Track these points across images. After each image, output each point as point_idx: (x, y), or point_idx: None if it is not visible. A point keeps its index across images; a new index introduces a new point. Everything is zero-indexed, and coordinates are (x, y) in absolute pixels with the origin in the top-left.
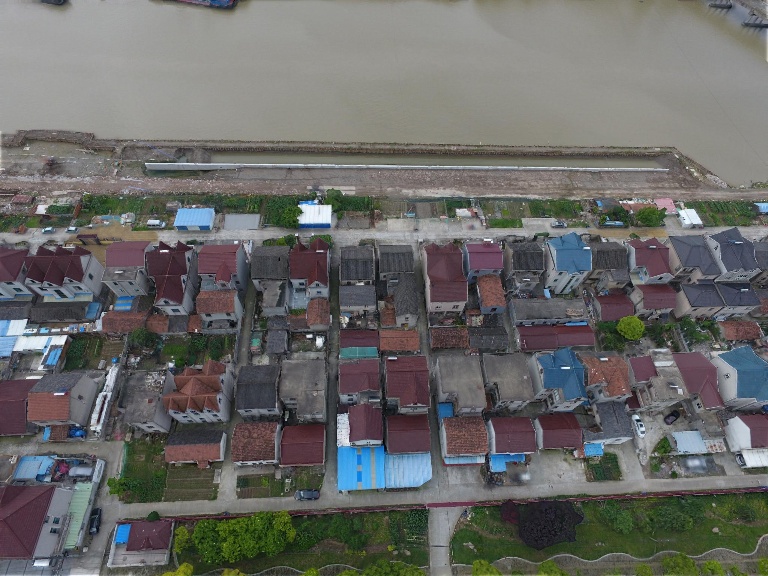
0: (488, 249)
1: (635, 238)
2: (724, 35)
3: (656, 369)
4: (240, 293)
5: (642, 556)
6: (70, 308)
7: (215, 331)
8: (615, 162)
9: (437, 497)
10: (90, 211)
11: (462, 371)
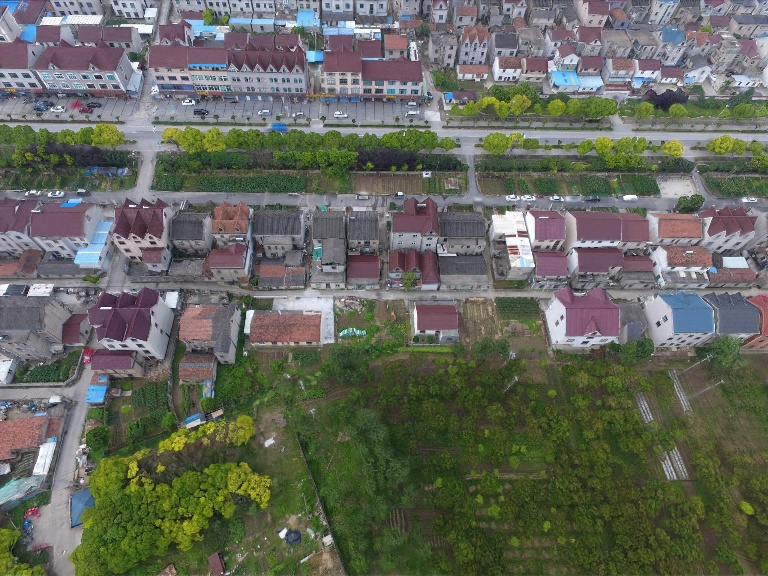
0: None
1: None
2: None
3: (723, 37)
4: None
5: None
6: (378, 16)
7: None
8: None
9: (606, 96)
10: None
11: (616, 35)
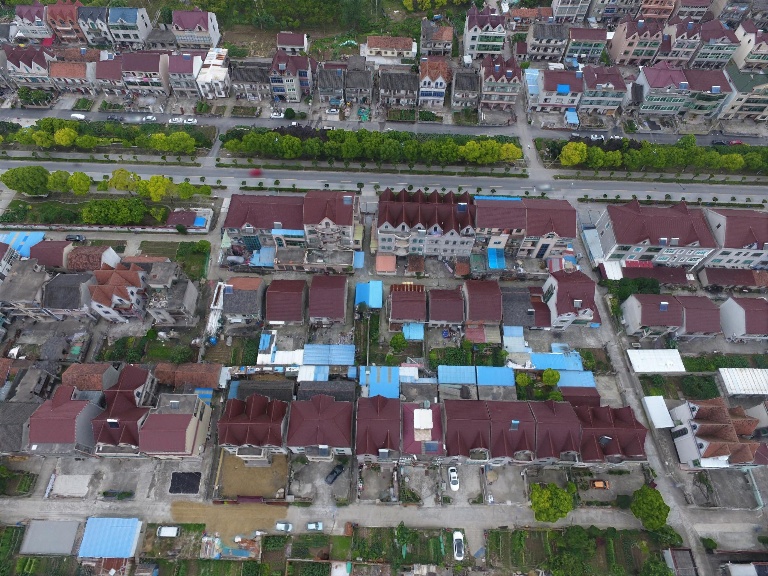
0: None
1: None
2: None
3: None
4: None
5: None
6: (252, 388)
7: None
8: None
9: None
10: (271, 575)
11: None
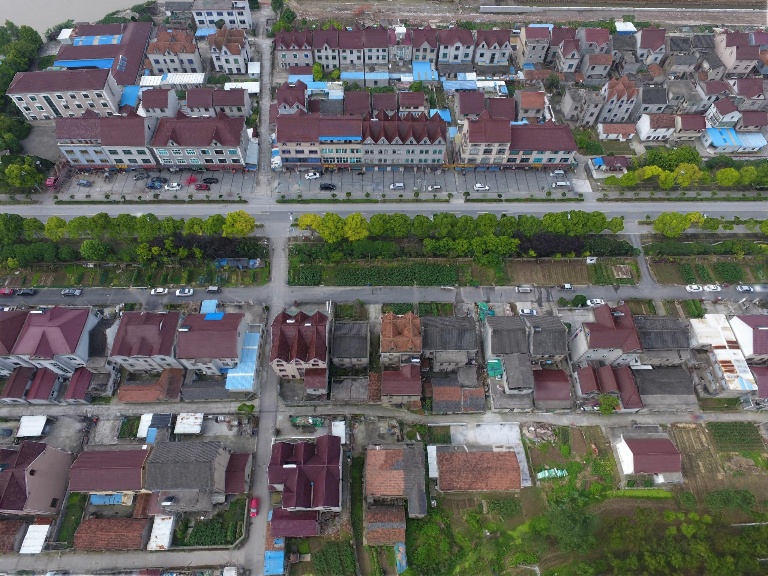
0: None
1: None
2: None
3: None
4: None
5: None
6: (501, 66)
7: (593, 81)
8: None
9: None
10: None
11: None
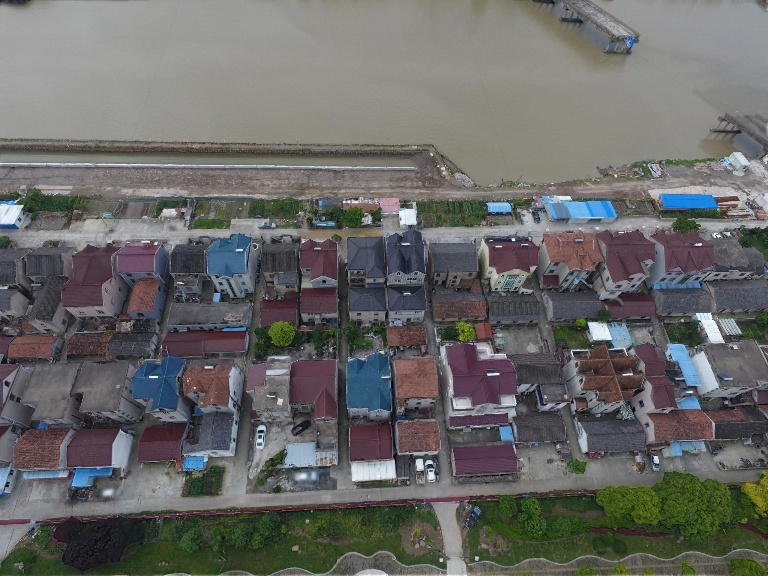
0: (143, 251)
1: (308, 239)
2: (548, 31)
3: (265, 378)
4: None
5: None
6: None
7: None
8: (368, 160)
9: (10, 513)
10: None
11: (54, 380)
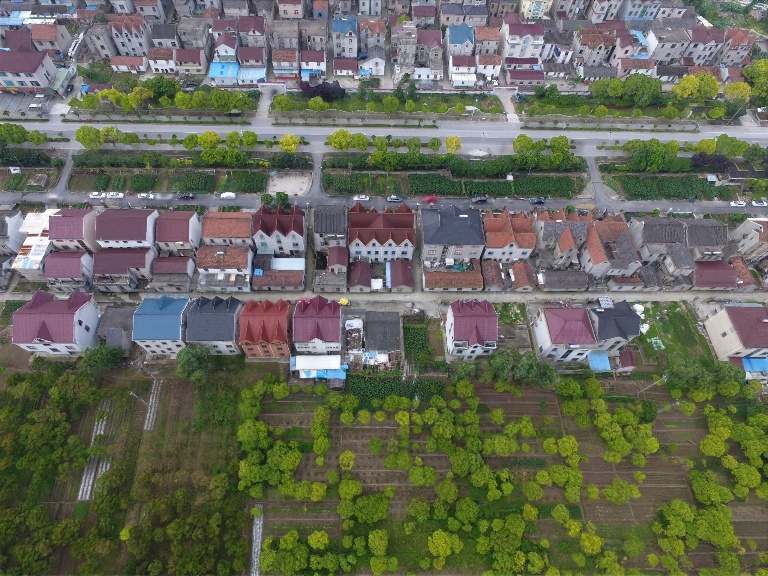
0: None
1: None
2: None
3: (403, 28)
4: (164, 9)
5: (379, 111)
6: (57, 6)
7: None
8: None
9: (268, 89)
10: None
11: (287, 25)
